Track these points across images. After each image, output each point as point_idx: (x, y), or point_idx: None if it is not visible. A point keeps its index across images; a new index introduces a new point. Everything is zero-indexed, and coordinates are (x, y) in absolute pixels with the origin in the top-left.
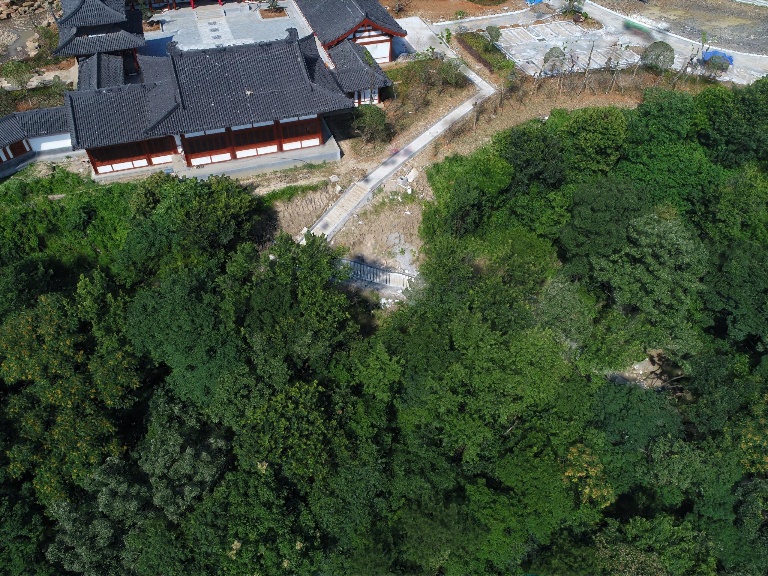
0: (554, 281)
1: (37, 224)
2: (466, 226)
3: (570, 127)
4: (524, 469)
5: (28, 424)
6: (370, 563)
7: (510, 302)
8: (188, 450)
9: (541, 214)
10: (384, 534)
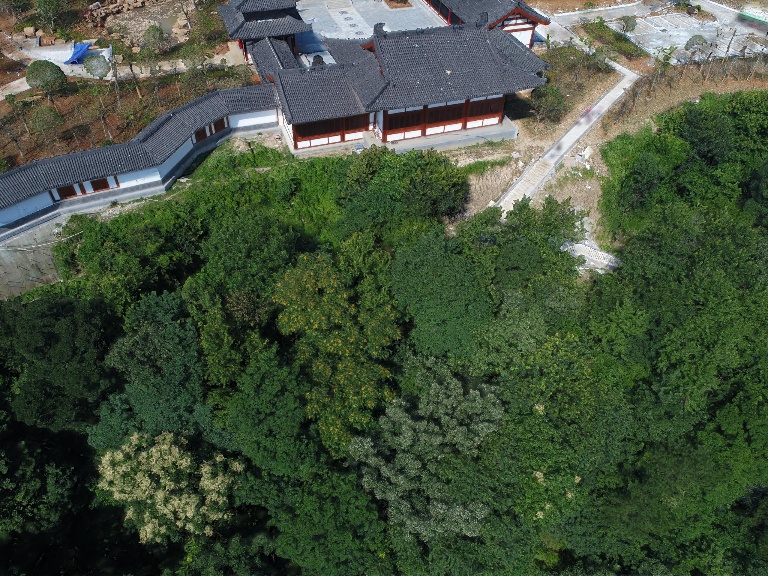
0: (763, 245)
1: (252, 194)
2: (643, 200)
3: (732, 108)
4: (750, 417)
5: (319, 369)
6: (643, 495)
7: (737, 262)
8: (476, 391)
9: (704, 190)
10: (631, 475)
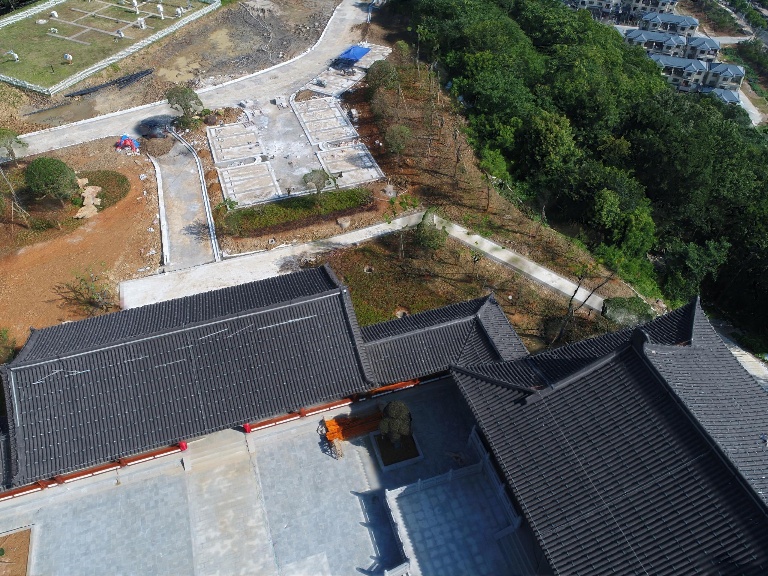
0: None
1: None
2: None
3: None
4: None
5: None
6: None
7: None
8: None
9: None
10: None
